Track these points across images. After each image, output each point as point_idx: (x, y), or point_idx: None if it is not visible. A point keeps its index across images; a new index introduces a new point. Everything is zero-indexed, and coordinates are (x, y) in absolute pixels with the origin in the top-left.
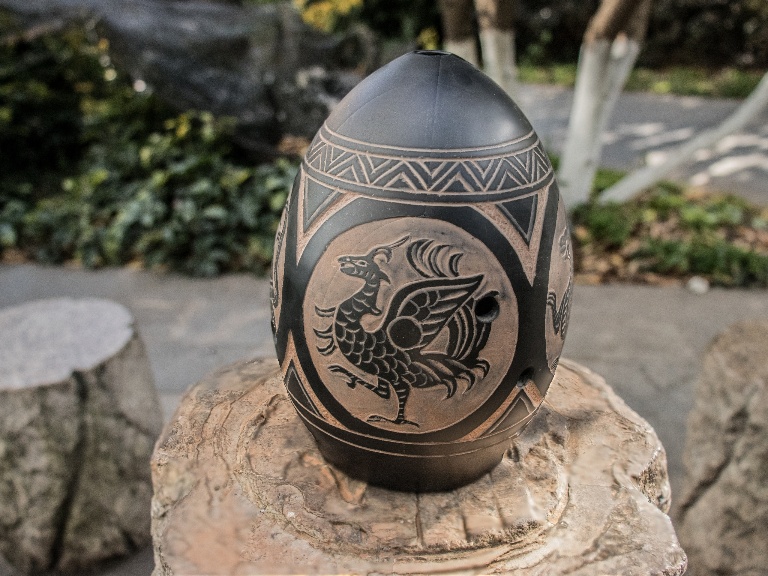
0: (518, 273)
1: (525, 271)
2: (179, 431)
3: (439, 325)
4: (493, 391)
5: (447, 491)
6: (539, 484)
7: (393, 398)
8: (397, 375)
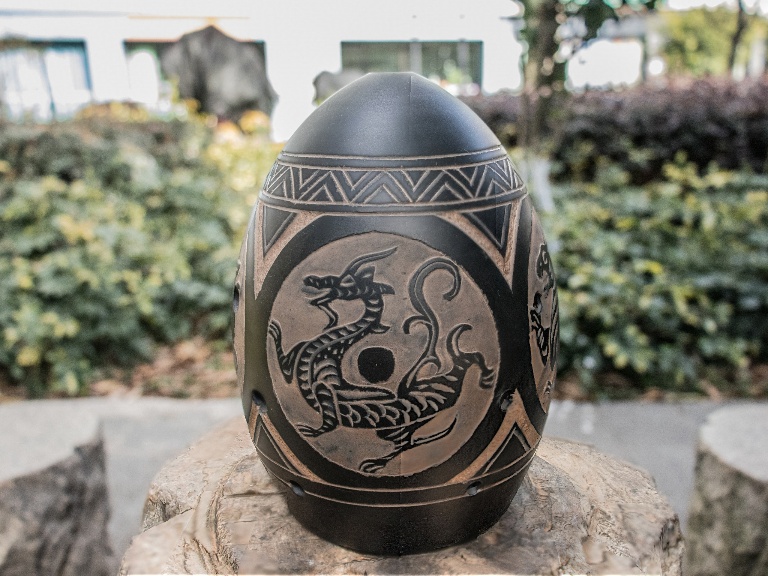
0: (250, 278)
1: (256, 280)
2: None
3: None
4: None
5: None
6: None
7: None
8: None
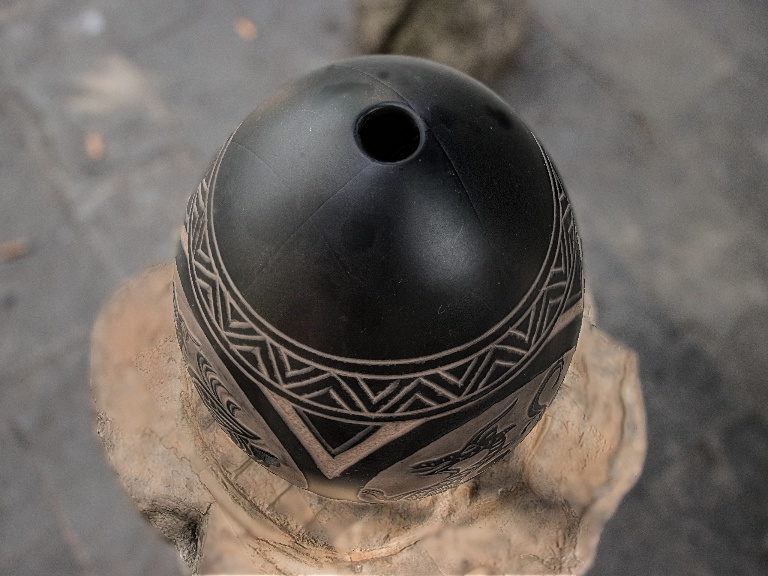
0: (308, 464)
1: (321, 467)
2: None
3: None
4: None
5: None
6: (393, 517)
7: None
8: None
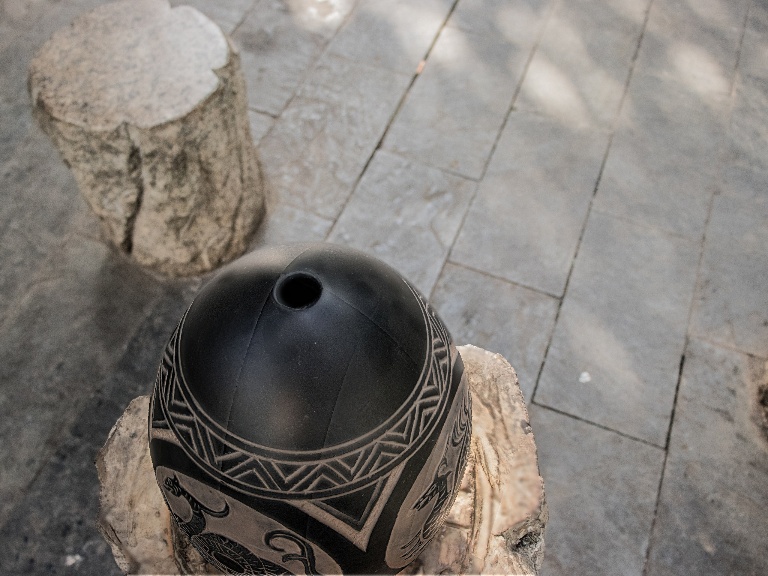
0: None
1: None
2: None
3: None
4: None
5: None
6: None
7: None
8: None
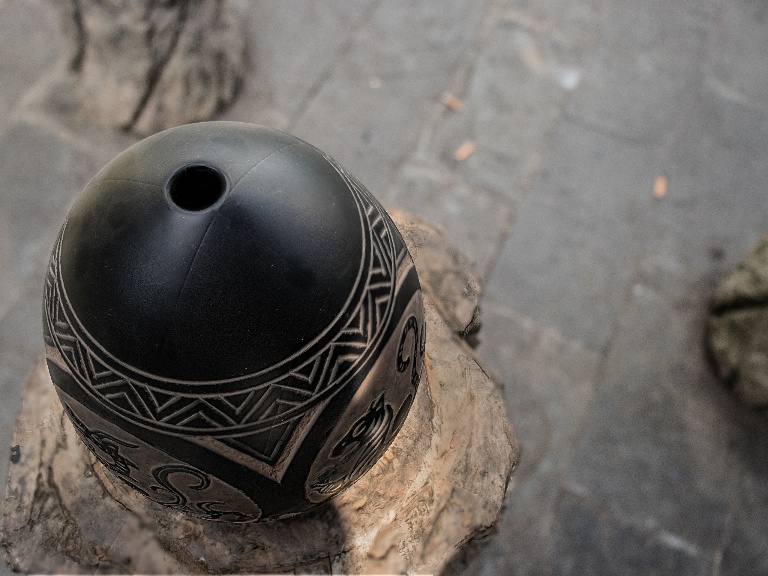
0: None
1: None
2: None
3: None
4: None
5: None
6: None
7: None
8: None
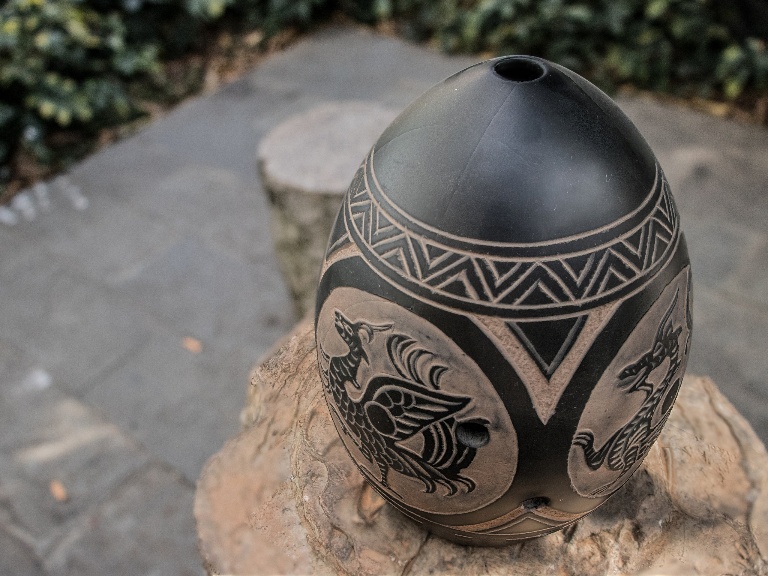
0: (523, 407)
1: (536, 406)
2: (284, 353)
3: (413, 429)
4: (484, 505)
5: (461, 545)
6: None
7: (375, 465)
8: (376, 450)
